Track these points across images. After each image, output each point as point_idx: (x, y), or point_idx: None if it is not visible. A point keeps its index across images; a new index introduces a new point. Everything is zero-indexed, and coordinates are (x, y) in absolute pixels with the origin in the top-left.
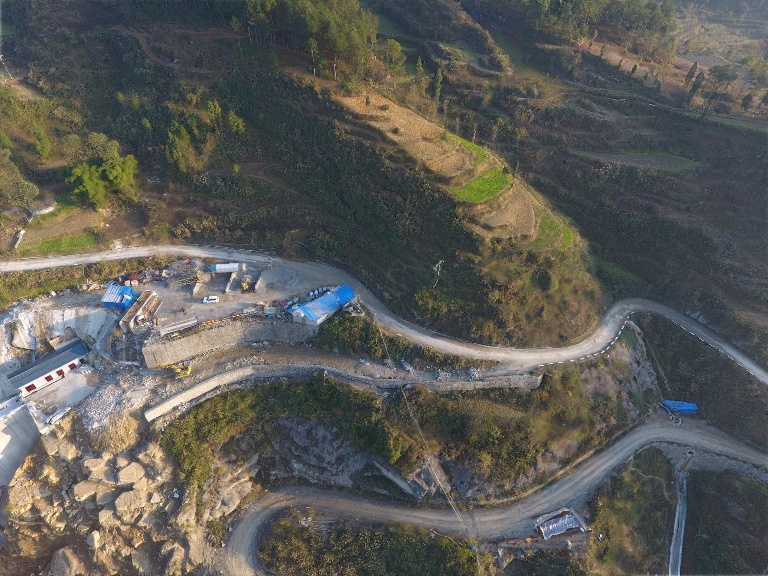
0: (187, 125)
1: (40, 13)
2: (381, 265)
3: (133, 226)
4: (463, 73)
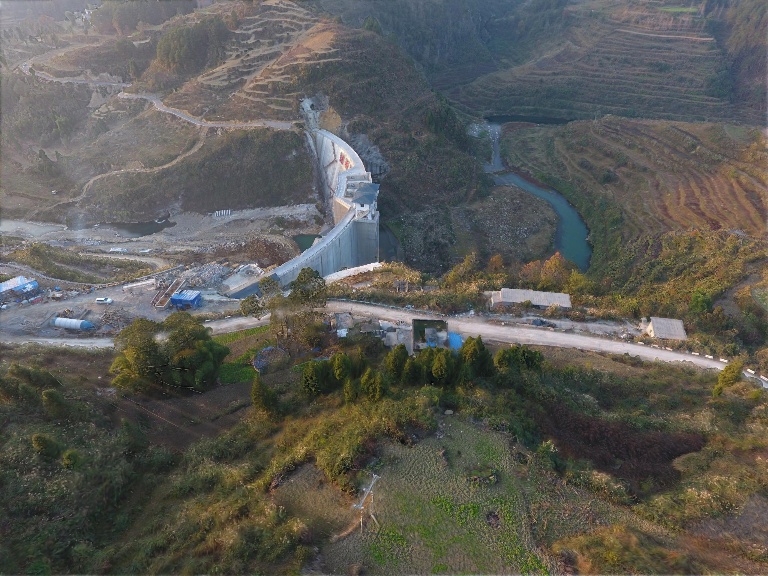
0: None
1: None
2: None
3: None
4: None
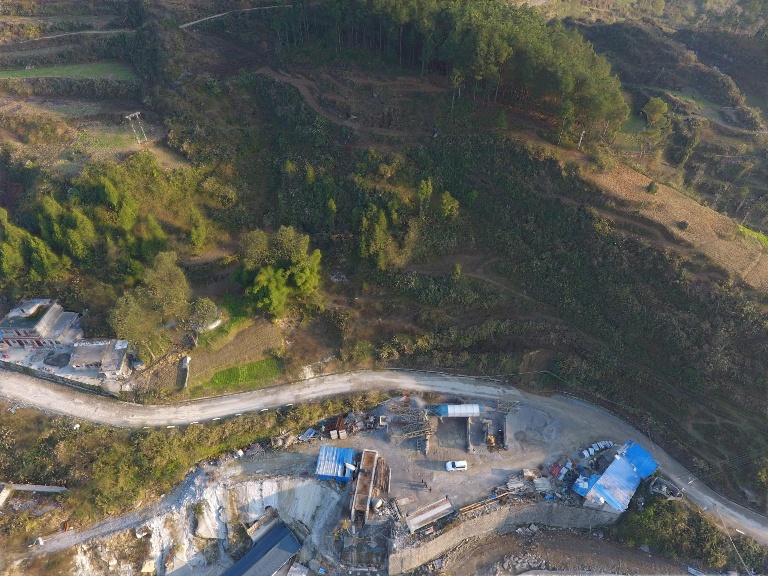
0: (383, 207)
1: (176, 55)
2: (672, 411)
3: (322, 344)
4: (708, 132)
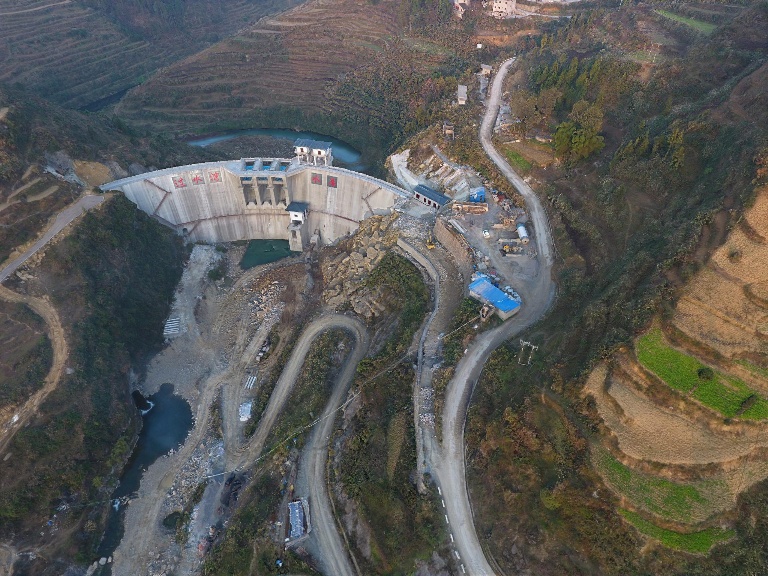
0: None
1: (732, 24)
2: None
3: (548, 178)
4: None
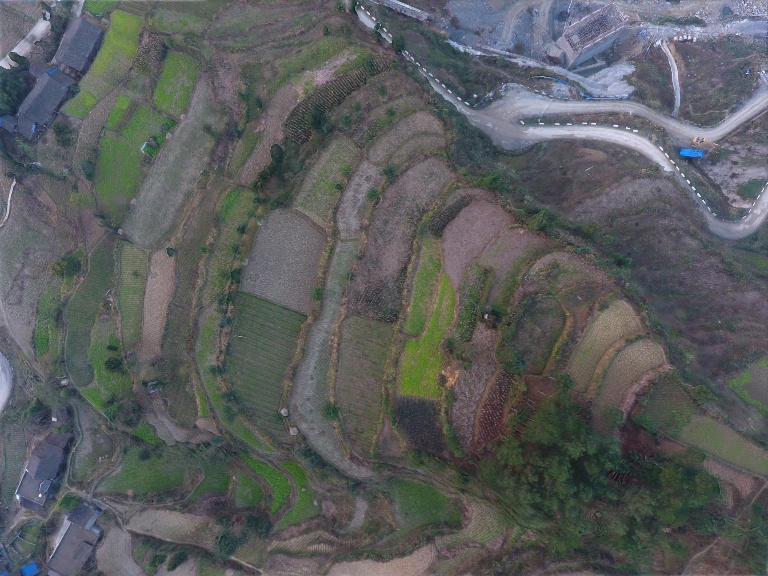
0: None
1: None
2: None
3: None
4: None
